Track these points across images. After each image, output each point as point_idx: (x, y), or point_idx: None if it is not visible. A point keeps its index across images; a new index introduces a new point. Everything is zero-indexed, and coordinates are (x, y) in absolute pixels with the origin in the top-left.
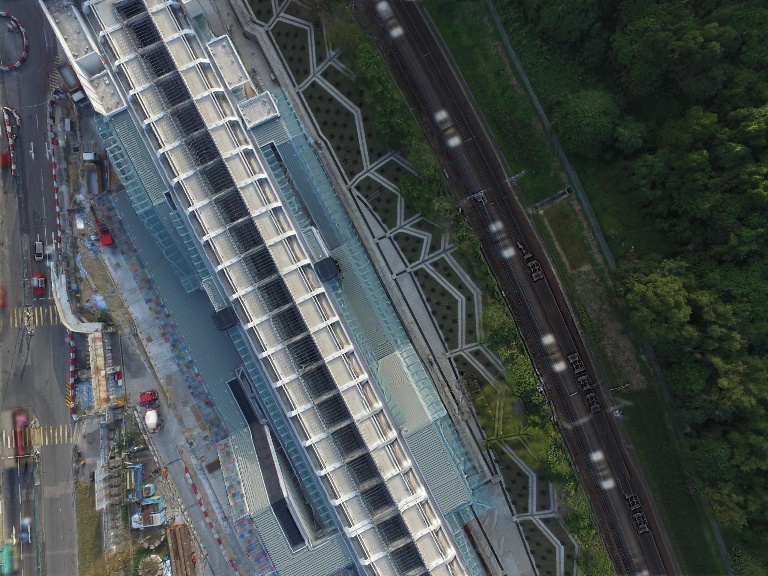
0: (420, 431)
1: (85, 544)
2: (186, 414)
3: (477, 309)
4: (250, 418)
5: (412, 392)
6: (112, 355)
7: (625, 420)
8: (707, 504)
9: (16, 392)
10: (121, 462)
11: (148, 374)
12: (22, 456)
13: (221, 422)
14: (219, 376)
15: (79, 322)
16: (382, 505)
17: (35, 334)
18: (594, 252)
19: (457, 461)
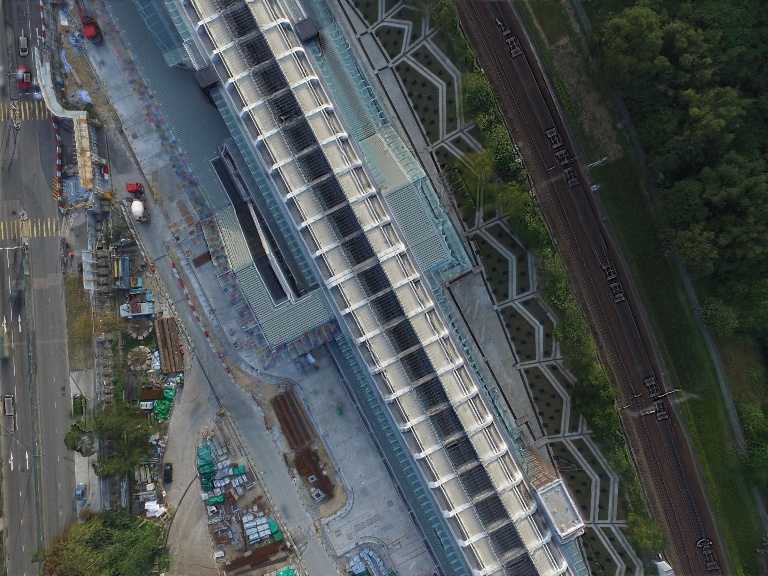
0: (399, 190)
1: (75, 333)
2: (172, 209)
3: (457, 94)
4: (234, 197)
5: (392, 161)
6: (98, 150)
7: (602, 195)
8: (680, 260)
9: (4, 185)
10: (109, 255)
11: (134, 170)
12: (11, 248)
13: (205, 201)
14: (203, 155)
15: (64, 109)
16: (362, 253)
17: (21, 129)
18: (571, 22)
19: (436, 221)
